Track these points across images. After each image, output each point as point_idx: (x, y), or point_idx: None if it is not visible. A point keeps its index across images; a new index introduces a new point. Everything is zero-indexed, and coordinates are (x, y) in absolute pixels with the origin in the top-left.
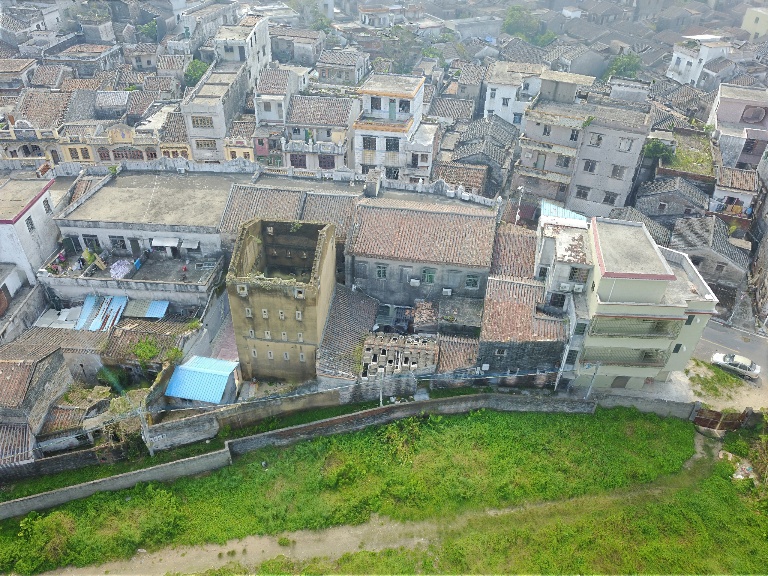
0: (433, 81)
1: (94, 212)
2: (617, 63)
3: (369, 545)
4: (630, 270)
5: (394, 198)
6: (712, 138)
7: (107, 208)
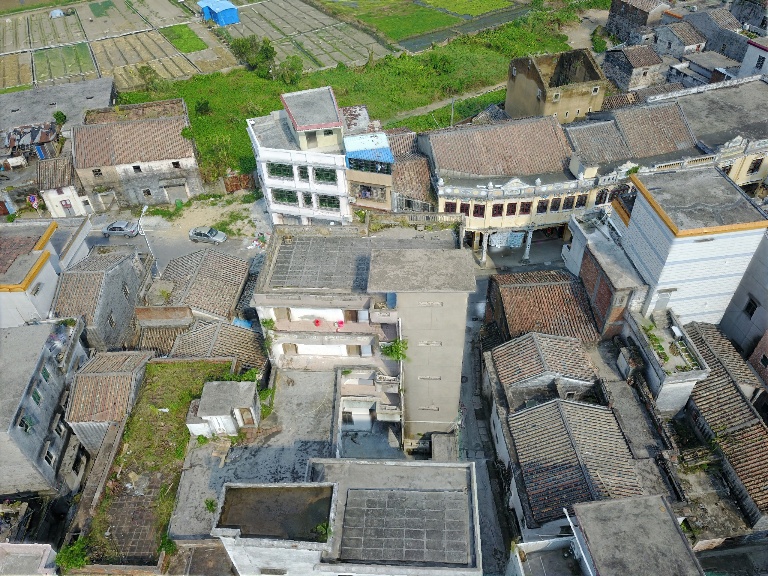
0: None
1: (760, 92)
2: None
3: (423, 108)
4: (312, 95)
5: (553, 177)
6: (65, 574)
7: (759, 96)
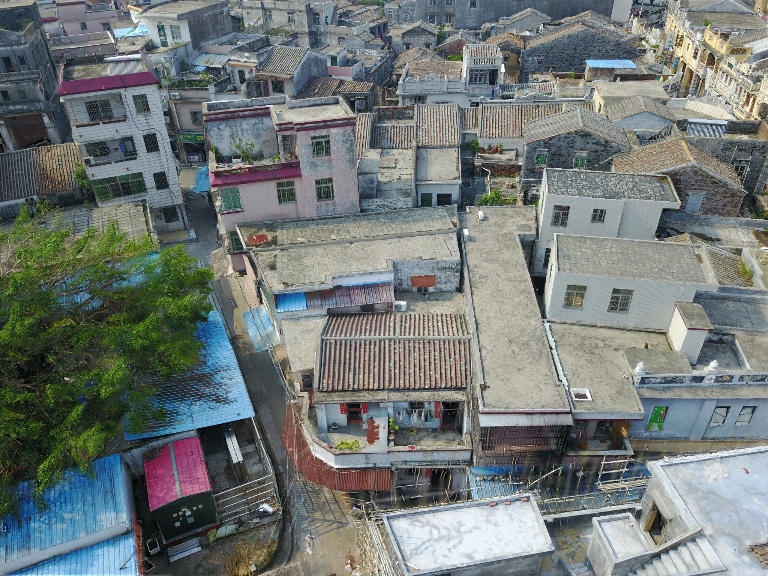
0: None
1: None
2: None
3: None
4: None
5: None
6: None
7: None
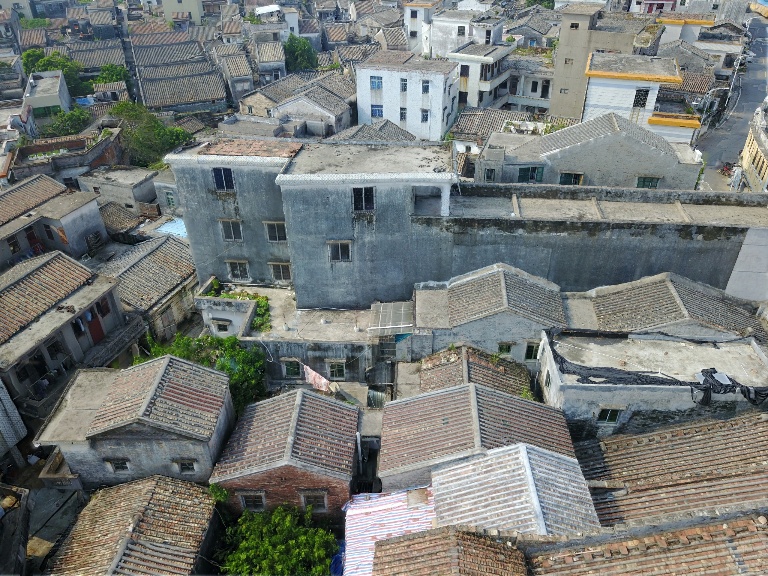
0: (325, 128)
1: None
2: (300, 47)
3: None
4: None
5: None
6: None
7: None
